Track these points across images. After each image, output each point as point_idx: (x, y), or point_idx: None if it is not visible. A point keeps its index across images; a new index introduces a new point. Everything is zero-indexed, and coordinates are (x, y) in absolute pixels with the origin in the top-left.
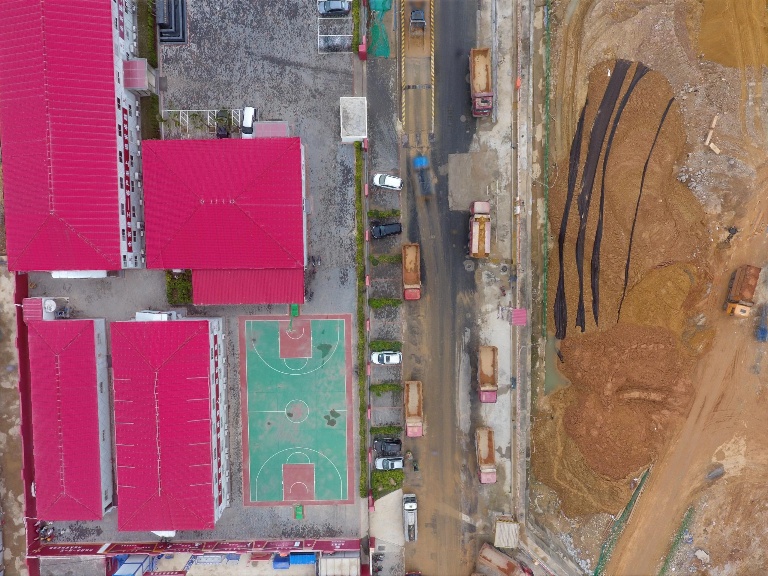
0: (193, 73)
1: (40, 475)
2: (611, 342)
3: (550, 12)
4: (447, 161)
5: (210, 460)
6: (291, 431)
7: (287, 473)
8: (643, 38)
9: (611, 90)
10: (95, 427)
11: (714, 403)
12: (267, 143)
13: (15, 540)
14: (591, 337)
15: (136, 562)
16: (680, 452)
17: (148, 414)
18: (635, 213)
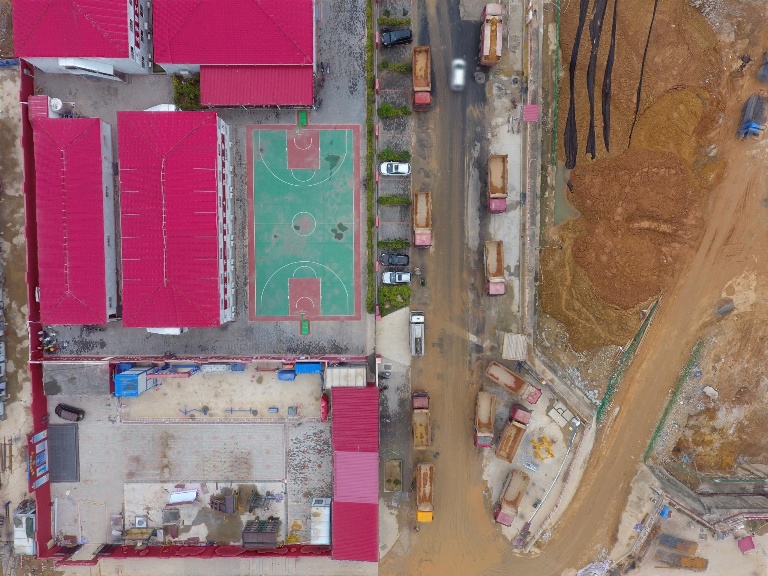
0: None
1: (44, 276)
2: (622, 166)
3: None
4: None
5: (216, 255)
6: (298, 244)
7: (293, 287)
8: None
9: None
10: (100, 228)
11: (725, 237)
12: None
13: (18, 352)
14: (601, 163)
15: (140, 370)
16: (690, 285)
17: (154, 203)
18: (647, 38)
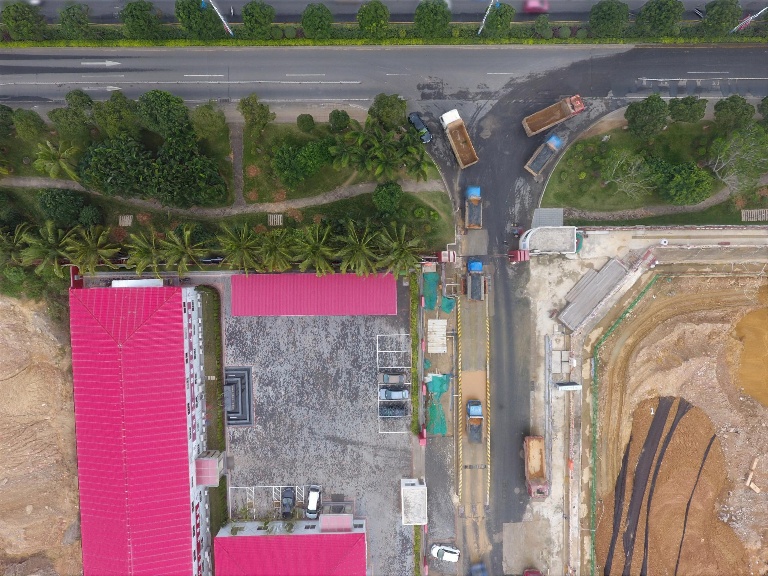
0: (259, 452)
1: None
2: None
3: (596, 357)
4: (501, 530)
5: None
6: None
7: None
8: (686, 380)
9: (655, 429)
10: None
11: None
12: (334, 540)
13: None
14: None
15: None
16: None
17: None
18: (678, 553)
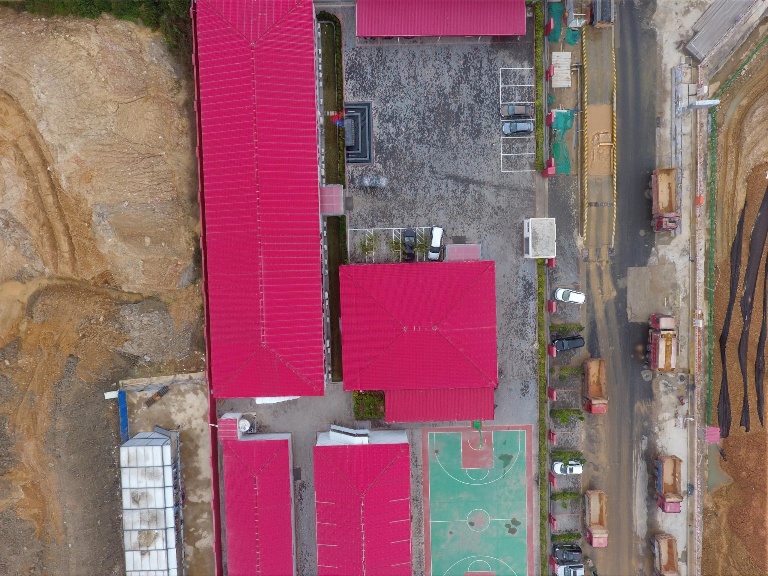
0: (379, 193)
1: None
2: None
3: None
4: (626, 274)
5: None
6: (472, 540)
7: None
8: None
9: None
10: (289, 544)
11: None
12: (463, 267)
13: None
14: (757, 438)
15: None
16: None
17: (353, 537)
18: None
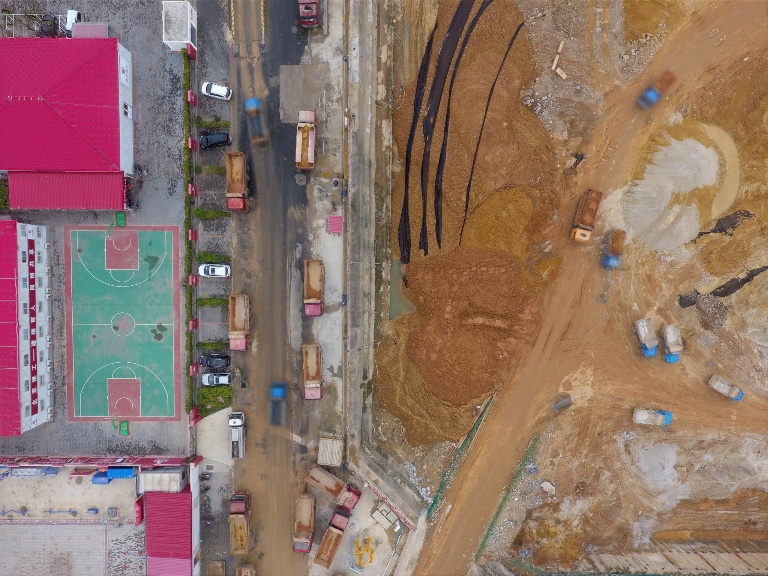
0: None
1: None
2: (451, 264)
3: None
4: (278, 72)
5: (16, 364)
6: (117, 345)
7: (112, 388)
8: None
9: (460, 14)
10: None
11: (561, 332)
12: (83, 43)
13: None
14: (433, 260)
15: None
16: (526, 381)
17: None
18: (479, 136)
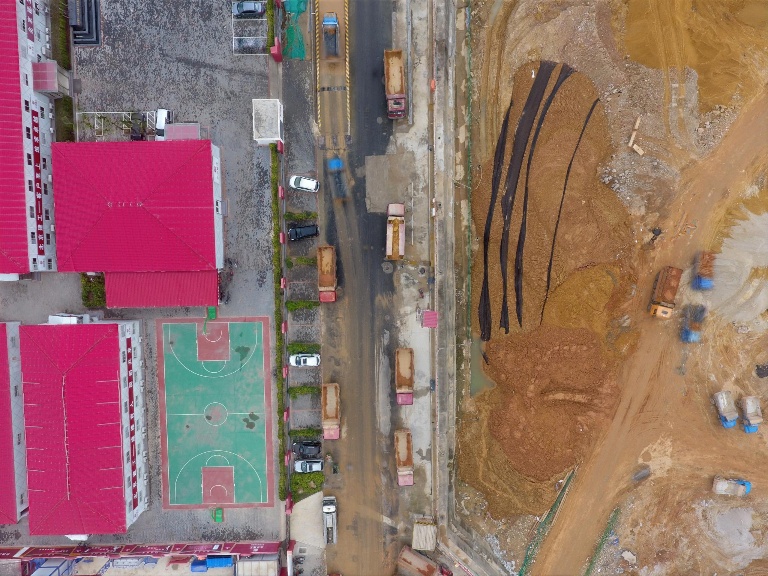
0: (107, 75)
1: None
2: (533, 344)
3: (473, 13)
4: (364, 163)
5: (121, 464)
6: (210, 434)
7: (206, 476)
8: (567, 39)
9: (535, 91)
10: (9, 431)
11: (640, 404)
12: (177, 145)
13: None
14: (514, 339)
15: (52, 566)
16: (606, 453)
17: (56, 418)
18: (558, 215)
